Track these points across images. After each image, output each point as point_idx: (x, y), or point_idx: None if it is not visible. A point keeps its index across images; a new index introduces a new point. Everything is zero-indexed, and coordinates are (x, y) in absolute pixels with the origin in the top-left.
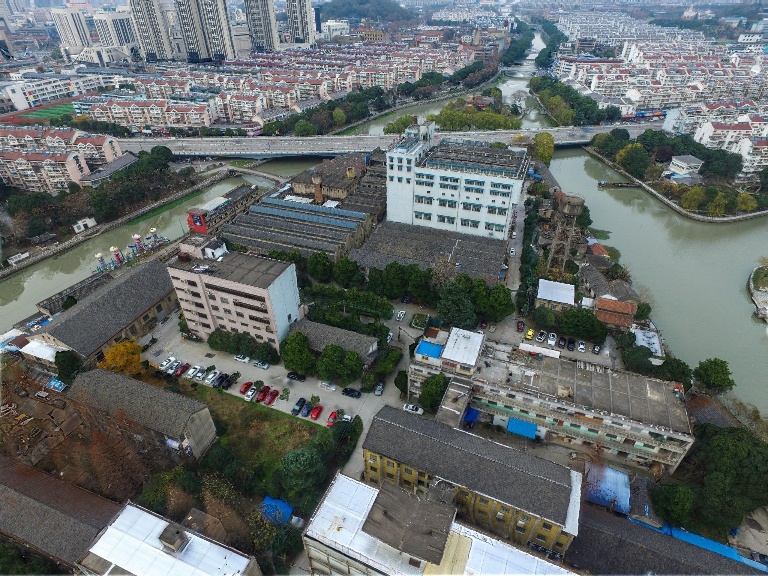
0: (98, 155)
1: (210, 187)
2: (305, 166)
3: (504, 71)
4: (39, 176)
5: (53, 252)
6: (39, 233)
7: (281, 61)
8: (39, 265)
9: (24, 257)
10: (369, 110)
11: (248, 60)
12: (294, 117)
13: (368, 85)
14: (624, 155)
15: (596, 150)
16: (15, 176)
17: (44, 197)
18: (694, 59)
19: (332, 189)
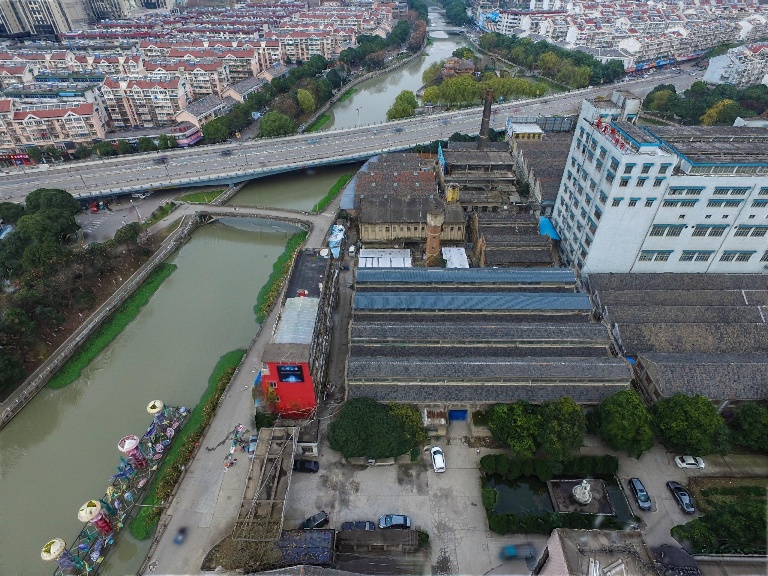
0: None
1: (176, 252)
2: (310, 185)
3: (427, 31)
4: None
5: None
6: None
7: (154, 29)
8: None
9: None
10: None
11: (102, 30)
12: (241, 108)
13: (297, 55)
14: (717, 116)
15: (648, 113)
16: None
17: None
18: (629, 7)
19: None
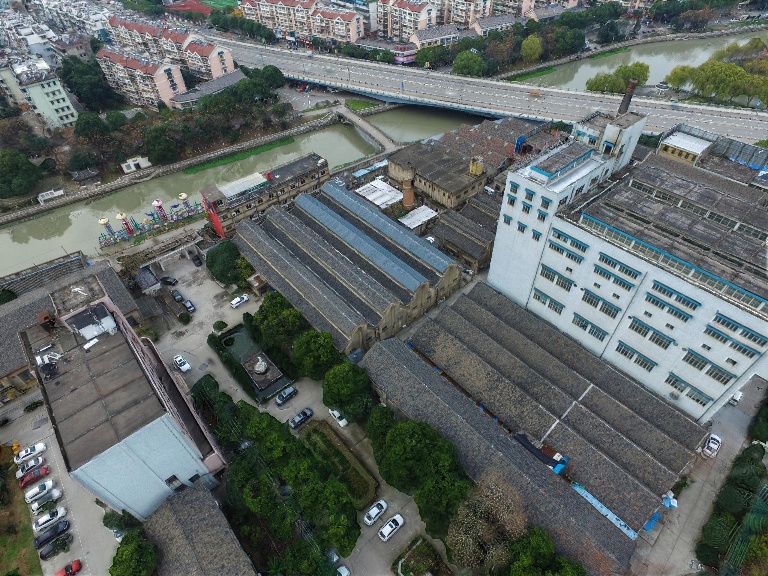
0: (204, 68)
1: (307, 134)
2: (443, 124)
3: None
4: (136, 87)
5: (89, 194)
6: (80, 168)
7: None
8: (72, 207)
9: (58, 195)
10: (587, 41)
11: None
12: (466, 42)
13: None
14: None
15: None
16: (120, 82)
17: (96, 123)
18: None
19: (436, 188)
